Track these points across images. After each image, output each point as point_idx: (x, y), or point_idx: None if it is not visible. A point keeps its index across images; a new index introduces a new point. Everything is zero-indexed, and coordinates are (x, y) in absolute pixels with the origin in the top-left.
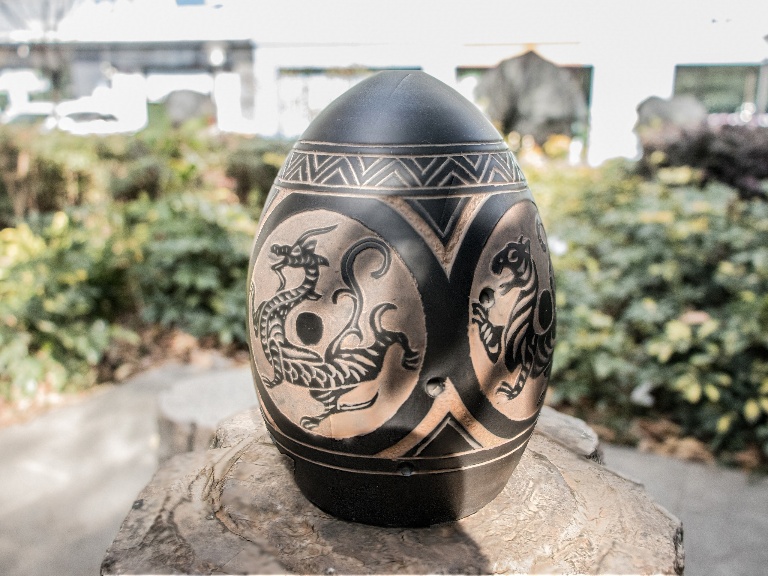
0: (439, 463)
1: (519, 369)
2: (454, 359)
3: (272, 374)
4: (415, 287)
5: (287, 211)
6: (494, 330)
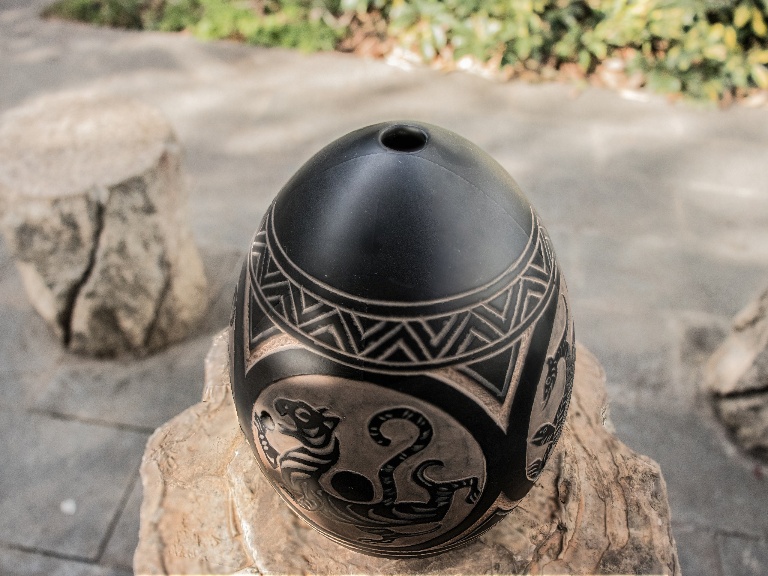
0: None
1: (302, 495)
2: None
3: None
4: None
5: None
6: (270, 447)
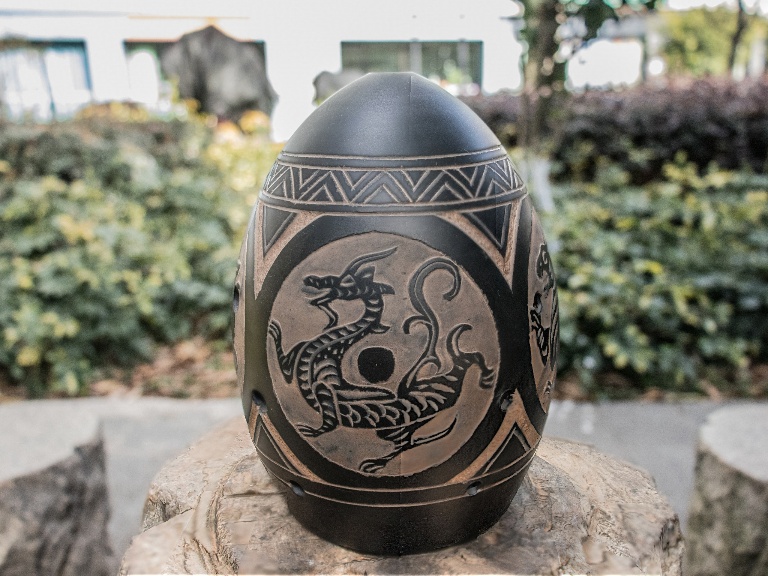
0: (501, 474)
1: (554, 366)
2: (521, 369)
3: (319, 421)
4: (486, 303)
5: (322, 237)
6: (544, 333)
